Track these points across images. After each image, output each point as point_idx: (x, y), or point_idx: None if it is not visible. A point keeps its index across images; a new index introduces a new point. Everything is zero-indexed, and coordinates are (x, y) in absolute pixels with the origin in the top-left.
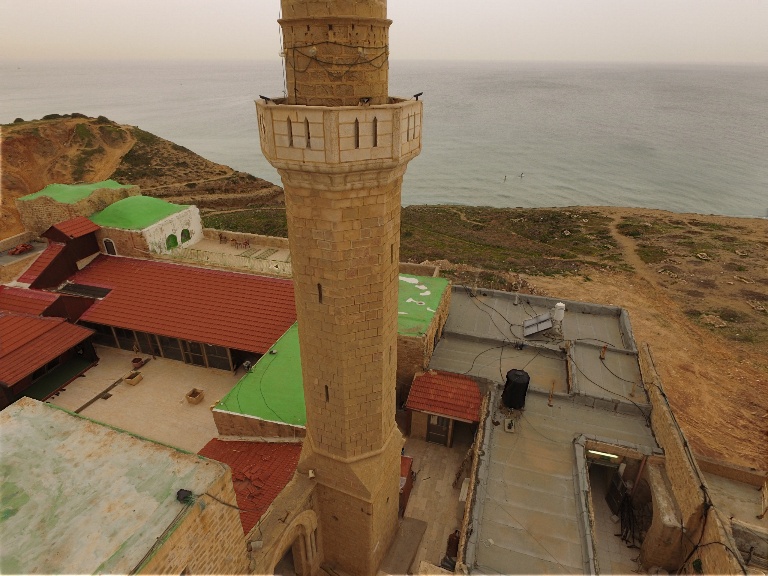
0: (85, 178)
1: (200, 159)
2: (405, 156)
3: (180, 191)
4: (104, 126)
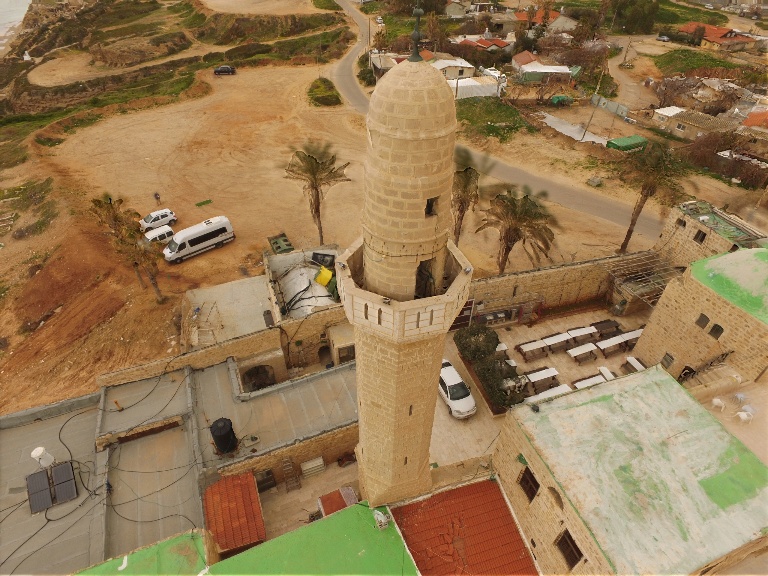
0: None
1: None
2: None
3: None
4: None
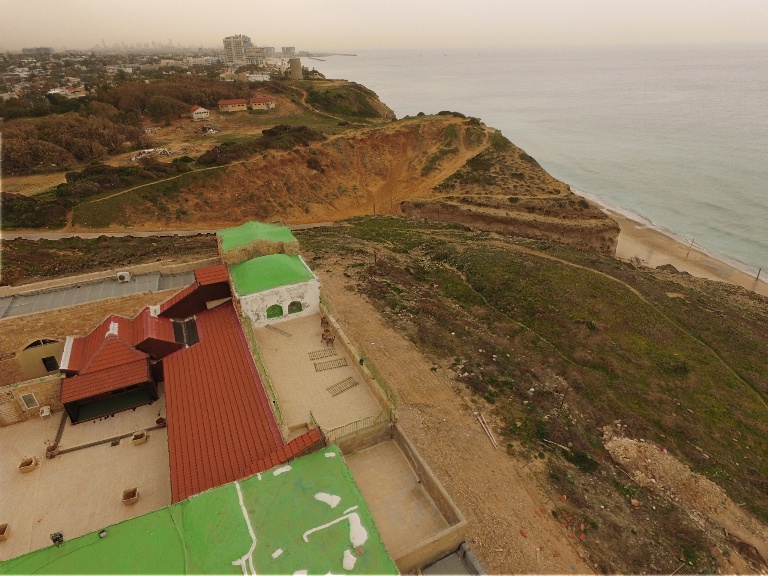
0: (430, 175)
1: (541, 172)
2: None
3: (500, 203)
4: (471, 128)
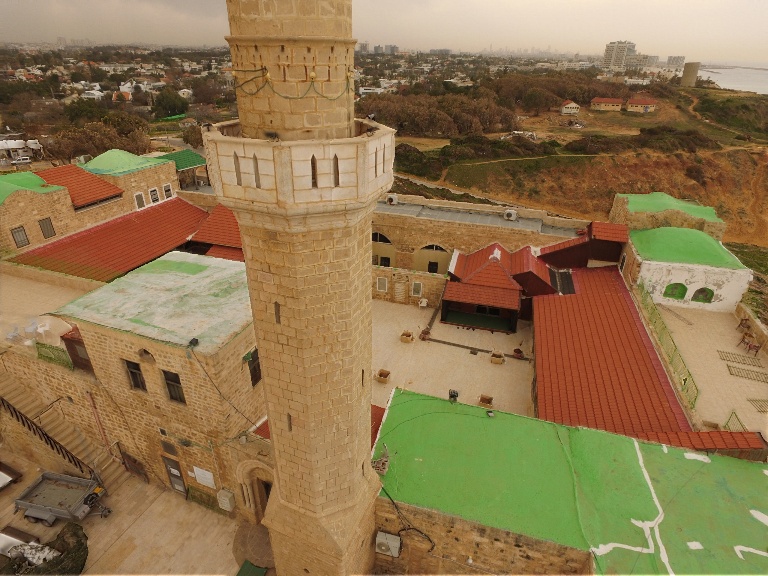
0: None
1: None
2: (238, 201)
3: None
4: None
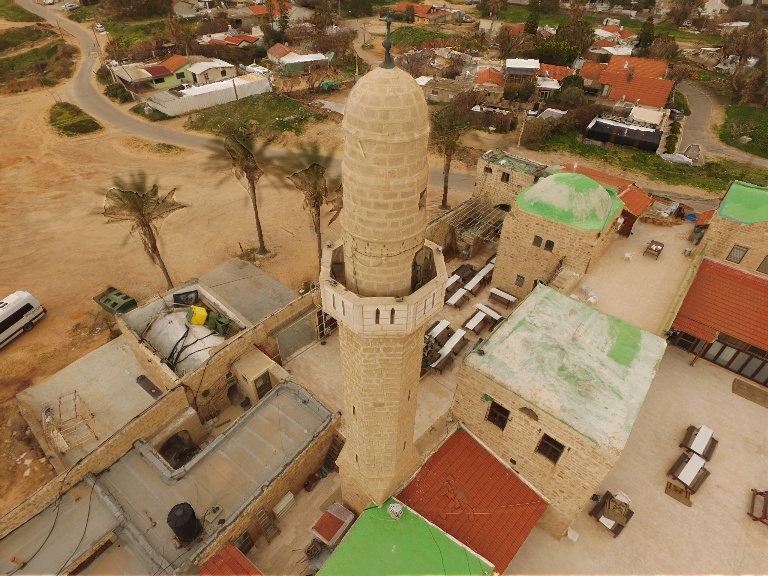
0: None
1: None
2: None
3: None
4: None
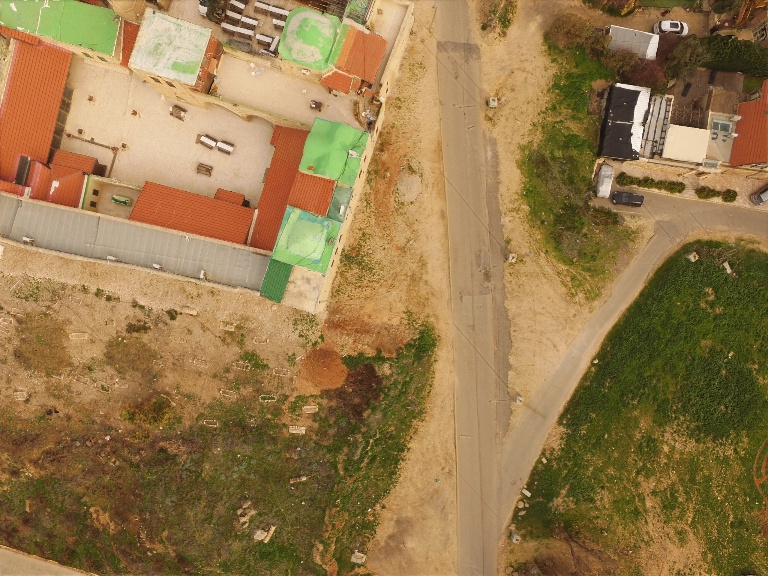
0: None
1: None
2: None
3: None
4: None
